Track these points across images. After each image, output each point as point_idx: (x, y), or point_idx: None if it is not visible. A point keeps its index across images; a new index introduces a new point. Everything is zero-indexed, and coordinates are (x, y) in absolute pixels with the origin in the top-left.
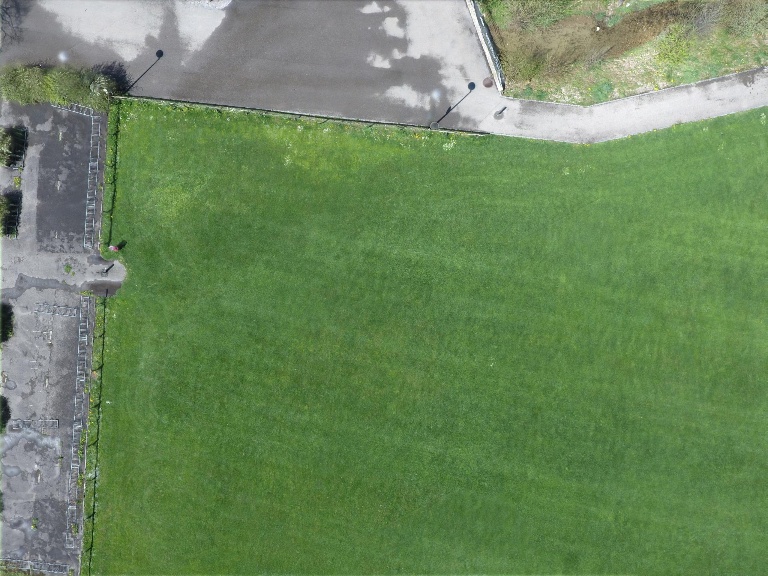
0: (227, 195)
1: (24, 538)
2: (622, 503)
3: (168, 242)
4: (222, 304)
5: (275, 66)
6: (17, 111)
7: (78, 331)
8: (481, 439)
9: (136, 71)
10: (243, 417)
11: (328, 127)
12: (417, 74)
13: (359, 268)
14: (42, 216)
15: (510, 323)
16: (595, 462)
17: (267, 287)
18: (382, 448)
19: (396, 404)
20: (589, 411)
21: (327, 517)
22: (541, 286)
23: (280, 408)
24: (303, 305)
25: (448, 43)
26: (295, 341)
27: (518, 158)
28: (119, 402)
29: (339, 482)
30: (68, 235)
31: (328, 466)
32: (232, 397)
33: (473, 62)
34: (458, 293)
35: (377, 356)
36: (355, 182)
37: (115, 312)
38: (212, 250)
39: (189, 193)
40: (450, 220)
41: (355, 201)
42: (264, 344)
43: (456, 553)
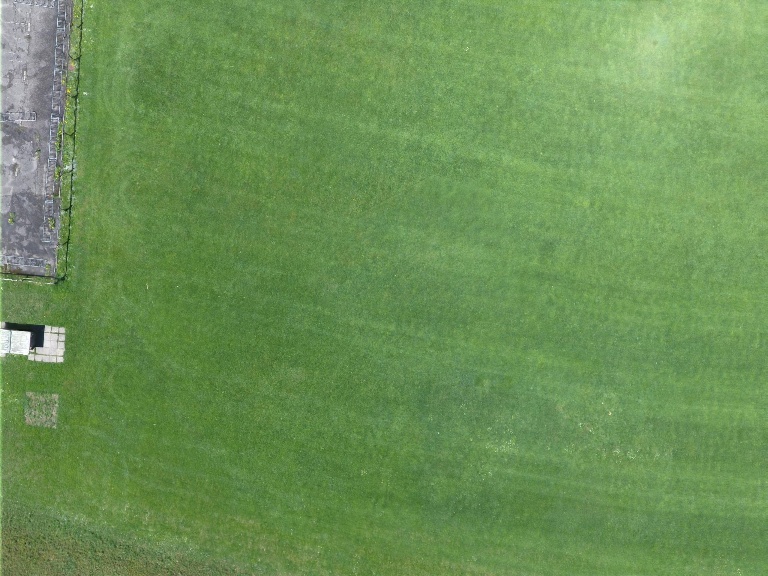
0: None
1: (1, 233)
2: (597, 187)
3: None
4: None
5: None
6: None
7: (56, 23)
8: (456, 124)
9: None
10: (219, 107)
11: None
12: None
13: None
14: None
15: (485, 6)
16: (569, 145)
17: None
18: (357, 136)
19: (371, 91)
20: (563, 94)
21: (302, 206)
22: None
23: (256, 97)
24: None
25: None
26: (271, 29)
27: None
28: (96, 93)
29: (314, 170)
30: None
31: (303, 154)
32: (208, 86)
33: None
34: None
35: (352, 42)
36: None
37: (93, 2)
38: None
39: None
40: None
41: None
42: (240, 32)
43: (431, 240)
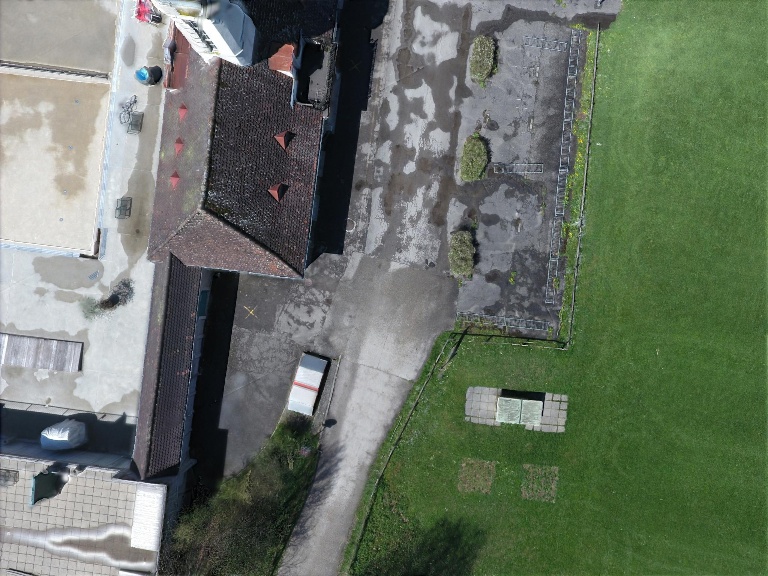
0: None
1: (500, 293)
2: None
3: None
4: (728, 37)
5: None
6: None
7: (567, 68)
8: None
9: None
10: (745, 160)
11: None
12: None
13: None
14: None
15: None
16: None
17: None
18: None
19: None
20: None
21: None
22: None
23: None
24: None
25: None
26: None
27: None
28: (610, 144)
29: None
30: None
31: None
32: (734, 138)
33: None
34: None
35: None
36: None
37: (609, 47)
38: None
39: None
40: None
41: None
42: None
43: None
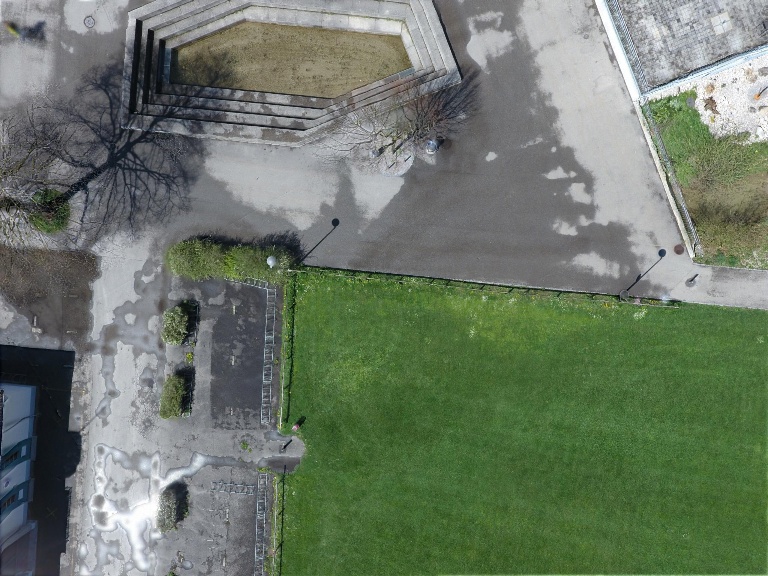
0: (410, 368)
1: None
2: None
3: (349, 417)
4: (406, 479)
5: (457, 234)
6: (188, 285)
7: (256, 508)
8: None
9: (311, 240)
10: None
11: (514, 297)
12: (606, 241)
13: (547, 440)
14: (216, 392)
15: (703, 493)
16: None
17: (453, 461)
18: None
19: (586, 575)
20: None
21: None
22: (735, 456)
23: None
24: (490, 479)
25: (638, 209)
26: (482, 515)
27: (711, 326)
28: None
29: None
30: (244, 411)
31: None
32: (417, 572)
33: (664, 228)
34: (650, 464)
35: (566, 528)
36: (543, 353)
37: (294, 489)
38: (395, 425)
39: (370, 366)
40: (641, 390)
41: (543, 372)
42: (450, 518)
43: None
